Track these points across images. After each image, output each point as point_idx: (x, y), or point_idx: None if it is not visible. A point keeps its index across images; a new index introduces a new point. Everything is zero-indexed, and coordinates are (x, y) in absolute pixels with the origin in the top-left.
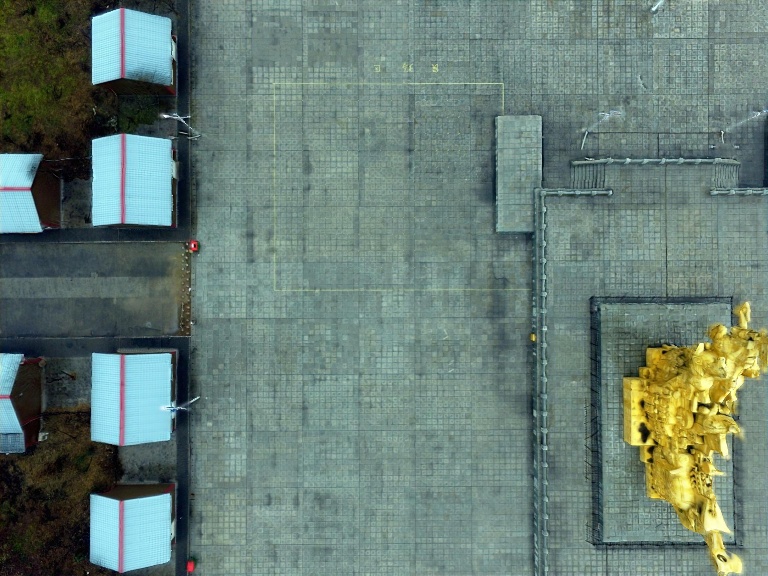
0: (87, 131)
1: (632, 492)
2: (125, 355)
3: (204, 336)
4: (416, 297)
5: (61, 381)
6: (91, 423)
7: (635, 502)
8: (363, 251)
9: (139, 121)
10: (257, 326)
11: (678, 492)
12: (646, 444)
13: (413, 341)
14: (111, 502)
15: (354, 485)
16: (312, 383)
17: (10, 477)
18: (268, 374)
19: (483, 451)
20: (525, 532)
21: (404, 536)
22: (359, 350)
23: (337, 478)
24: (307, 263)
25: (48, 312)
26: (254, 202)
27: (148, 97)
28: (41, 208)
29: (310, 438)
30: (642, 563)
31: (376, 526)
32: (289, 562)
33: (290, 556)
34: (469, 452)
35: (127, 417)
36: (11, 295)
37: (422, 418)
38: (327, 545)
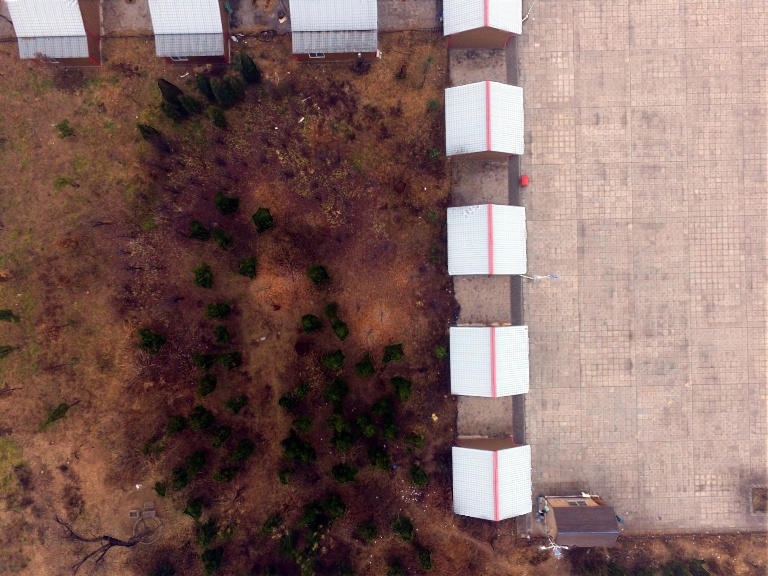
0: None
1: None
2: None
3: None
4: None
5: (392, 2)
6: (444, 18)
7: None
8: None
9: None
10: None
11: None
12: None
13: None
14: (474, 86)
15: (681, 103)
16: (638, 2)
17: (346, 96)
18: None
19: None
20: None
21: (732, 153)
22: None
23: (664, 96)
24: None
25: None
26: None
27: None
28: None
29: (637, 57)
30: None
31: (704, 143)
32: (618, 180)
33: (619, 174)
34: None
35: None
36: None
37: (749, 35)
38: (656, 163)
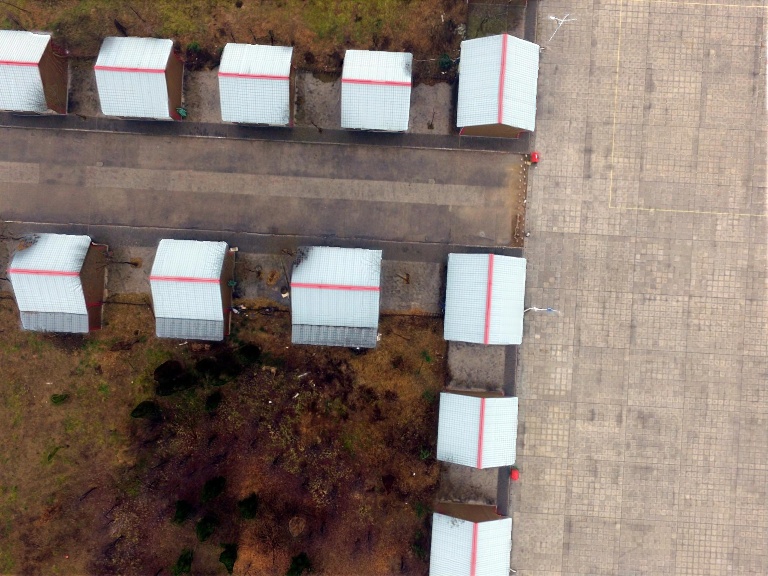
0: (437, 37)
1: None
2: (494, 254)
3: (537, 249)
4: (751, 222)
5: (395, 284)
6: (445, 322)
7: None
8: (701, 173)
9: (487, 30)
10: (590, 242)
11: None
12: None
13: (746, 266)
14: (470, 399)
15: (678, 406)
16: (642, 302)
17: (343, 375)
18: (598, 290)
19: None
20: None
21: (726, 460)
22: (691, 272)
23: (662, 398)
24: (644, 182)
25: (385, 215)
26: (594, 118)
27: (498, 6)
28: (410, 106)
29: (637, 357)
30: None
31: (698, 448)
32: (609, 478)
33: (611, 472)
34: None
35: (492, 316)
36: (350, 196)
37: (751, 344)
38: (648, 464)
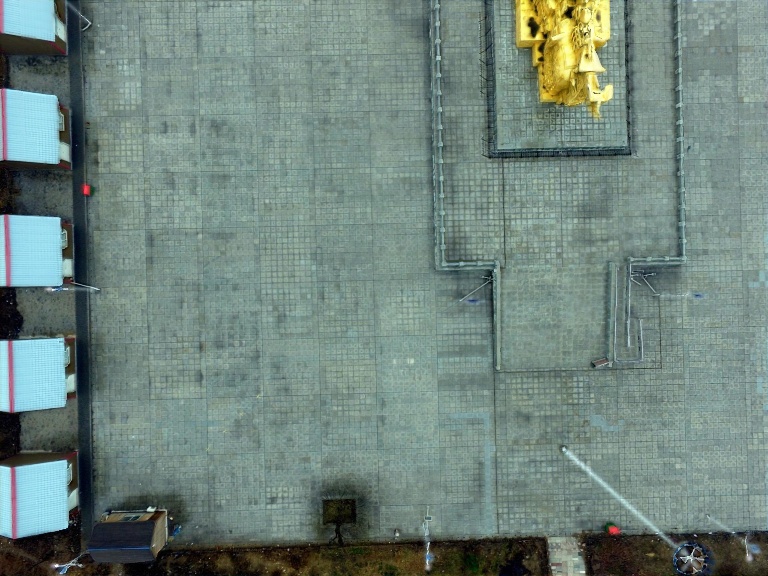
0: None
1: (525, 99)
2: None
3: None
4: None
5: None
6: None
7: (529, 109)
8: None
9: None
10: None
11: (561, 62)
12: (536, 39)
13: None
14: None
15: (251, 112)
16: (206, 9)
17: None
18: (160, 1)
19: (380, 76)
20: (424, 156)
21: (303, 162)
22: None
23: (234, 105)
24: None
25: None
26: None
27: None
28: None
29: (205, 65)
30: (538, 175)
31: (274, 152)
32: (188, 189)
33: (188, 183)
34: (366, 77)
35: (6, 5)
36: None
37: (318, 44)
38: (225, 172)
